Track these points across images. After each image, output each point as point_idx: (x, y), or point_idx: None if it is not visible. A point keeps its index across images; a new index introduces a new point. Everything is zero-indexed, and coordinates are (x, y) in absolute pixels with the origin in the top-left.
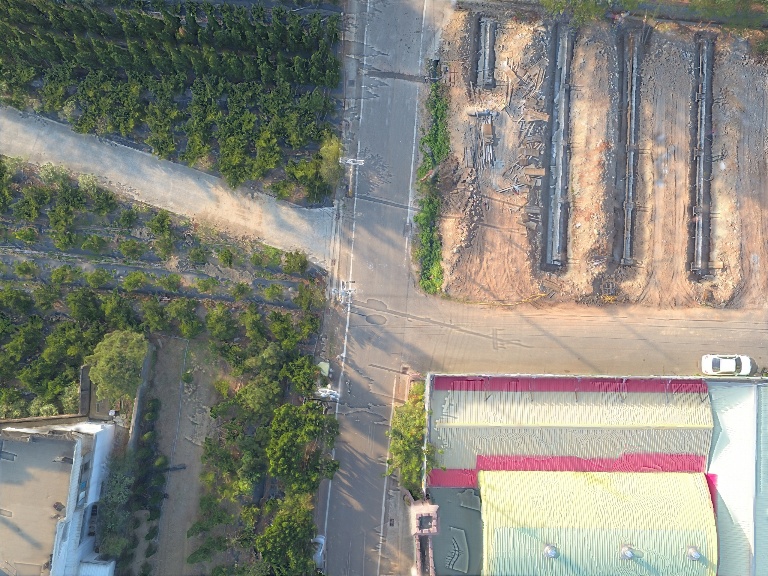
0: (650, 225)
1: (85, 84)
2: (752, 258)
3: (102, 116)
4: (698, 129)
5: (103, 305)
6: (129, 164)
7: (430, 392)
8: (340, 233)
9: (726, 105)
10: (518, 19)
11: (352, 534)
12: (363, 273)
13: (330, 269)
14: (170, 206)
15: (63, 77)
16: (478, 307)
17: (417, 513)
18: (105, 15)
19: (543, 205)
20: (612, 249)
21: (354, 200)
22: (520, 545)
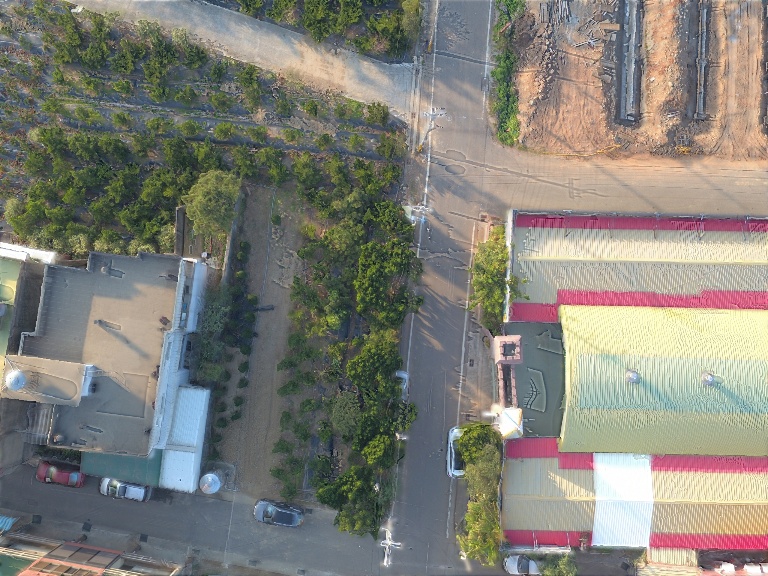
0: (723, 79)
1: None
2: None
3: None
4: None
5: (196, 151)
6: (218, 22)
7: (513, 226)
8: (420, 88)
9: None
10: None
11: (433, 373)
12: (442, 125)
13: (410, 122)
14: (257, 62)
15: None
16: (554, 158)
17: (501, 341)
18: None
19: (617, 60)
20: (685, 105)
21: (433, 56)
22: (601, 372)
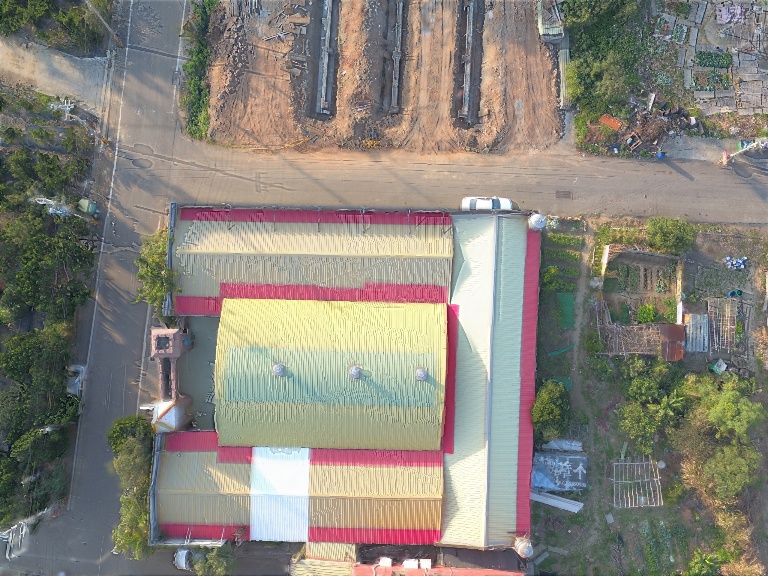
0: (416, 73)
1: None
2: (517, 104)
3: None
4: None
5: None
6: None
7: (170, 219)
8: (111, 82)
9: None
10: None
11: (113, 367)
12: (131, 119)
13: (100, 116)
14: None
15: None
16: (242, 151)
17: (154, 334)
18: None
19: (311, 54)
20: (382, 99)
21: (126, 50)
22: (254, 366)
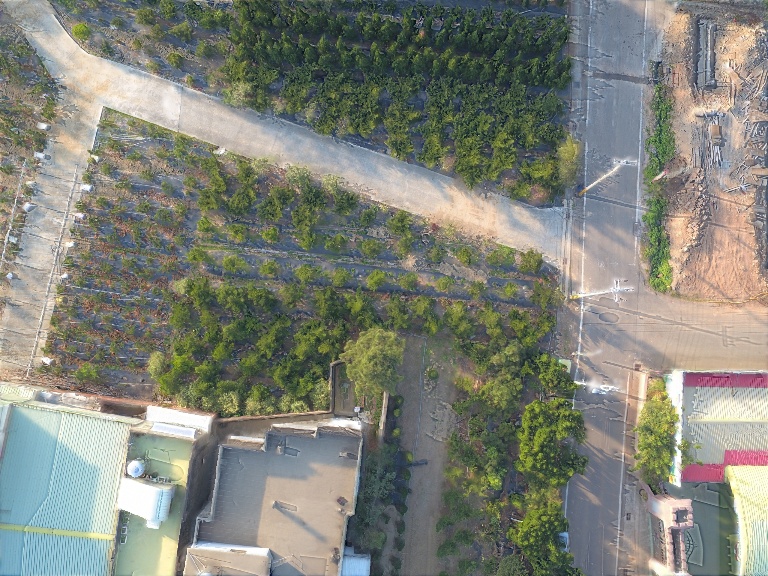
0: None
1: (326, 86)
2: None
3: (342, 118)
4: None
5: (350, 304)
6: (365, 165)
7: (683, 388)
8: (570, 232)
9: None
10: (738, 21)
11: (591, 528)
12: (595, 272)
13: (562, 268)
14: (406, 206)
15: (304, 79)
16: (707, 305)
17: (673, 507)
18: (344, 18)
19: (767, 204)
20: None
21: (583, 200)
22: None
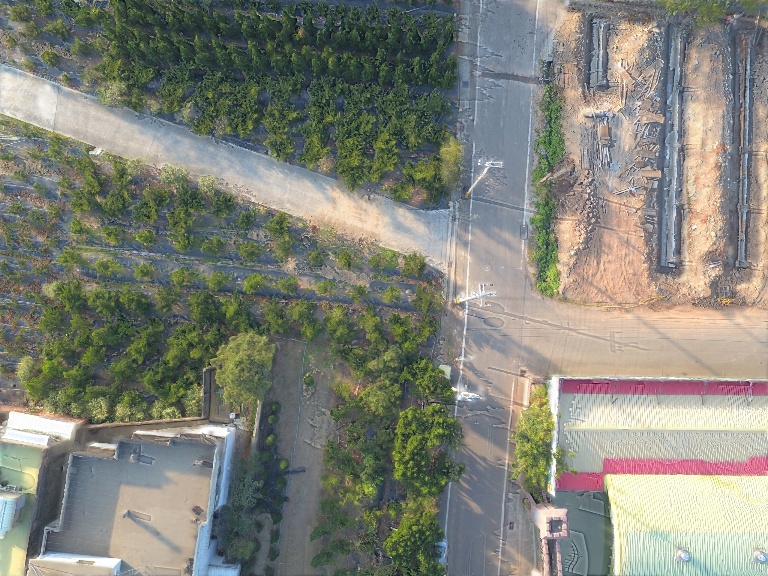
0: (765, 227)
1: (203, 85)
2: None
3: (220, 117)
4: None
5: (224, 307)
6: (246, 166)
7: (559, 395)
8: (456, 235)
9: None
10: (631, 20)
11: (472, 537)
12: (480, 275)
13: (447, 271)
14: (287, 208)
15: (181, 78)
16: (595, 310)
17: (547, 517)
18: (223, 16)
19: (658, 207)
20: None
21: (470, 202)
22: (650, 549)
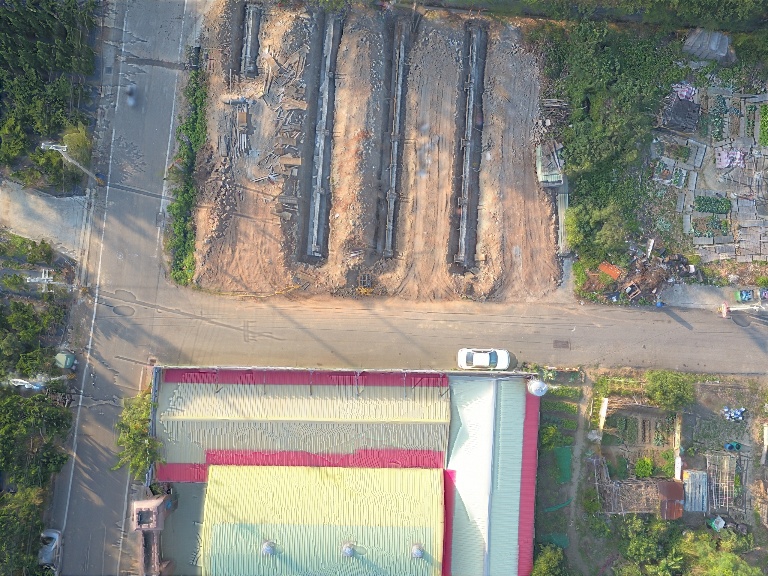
0: (411, 216)
1: None
2: (514, 250)
3: None
4: (466, 119)
5: None
6: None
7: (155, 384)
8: (91, 222)
9: (494, 94)
10: (282, 6)
11: (92, 529)
12: (112, 263)
13: (79, 259)
14: None
15: None
16: (230, 299)
17: (137, 507)
18: None
19: (302, 195)
20: (376, 241)
21: (106, 189)
22: (242, 541)
